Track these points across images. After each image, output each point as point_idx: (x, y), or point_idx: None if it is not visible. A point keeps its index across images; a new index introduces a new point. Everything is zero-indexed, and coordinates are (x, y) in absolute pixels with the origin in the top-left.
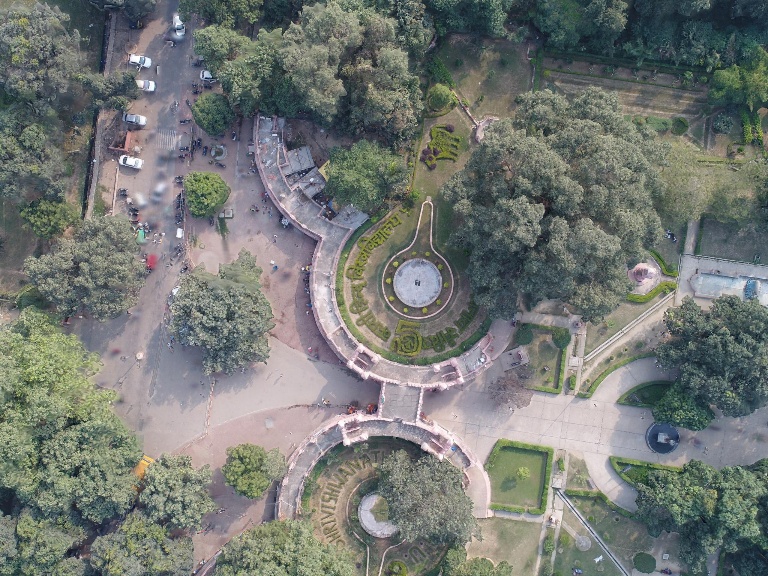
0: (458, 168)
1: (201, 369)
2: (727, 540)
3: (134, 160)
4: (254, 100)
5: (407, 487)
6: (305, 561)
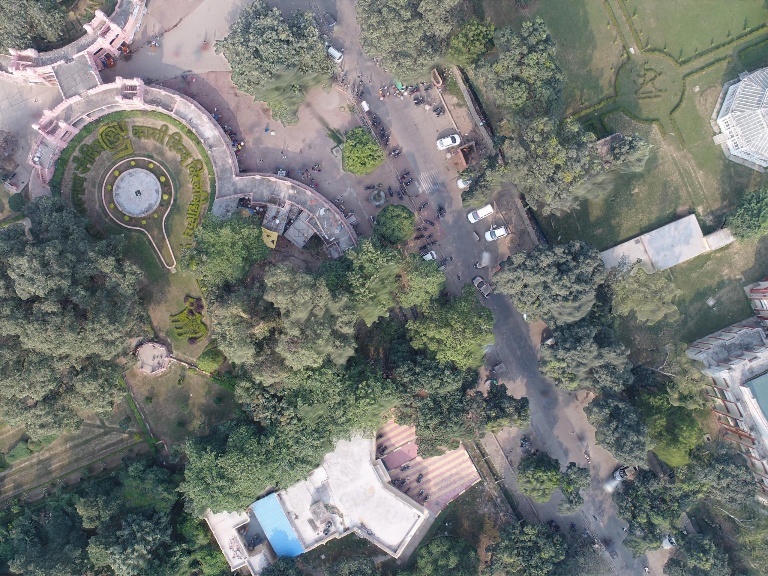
0: (165, 311)
1: (277, 4)
2: None
3: (446, 144)
4: None
5: (19, 5)
6: None
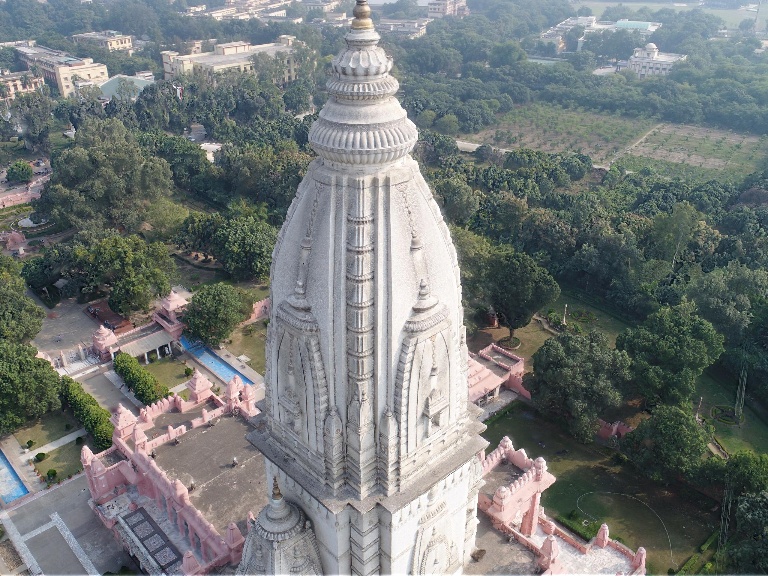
0: None
1: None
2: None
3: None
4: None
5: None
6: None
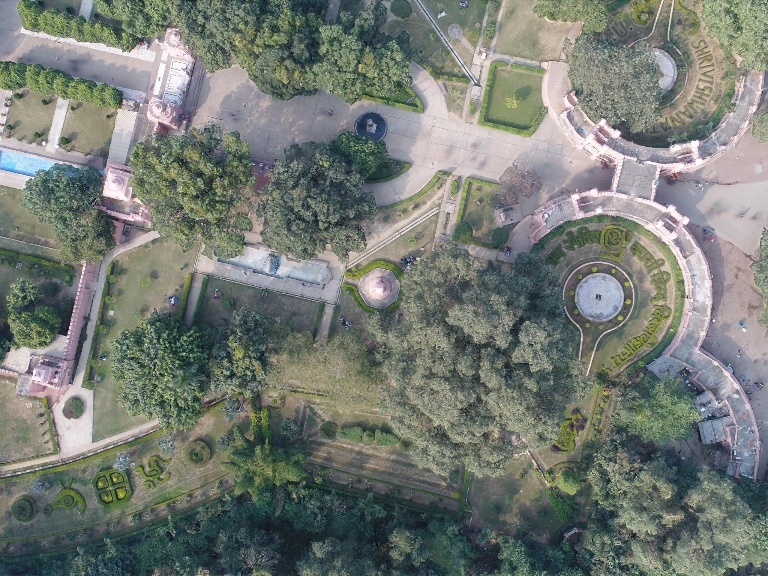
0: None
1: None
2: (350, 24)
3: None
4: None
5: None
6: (762, 28)
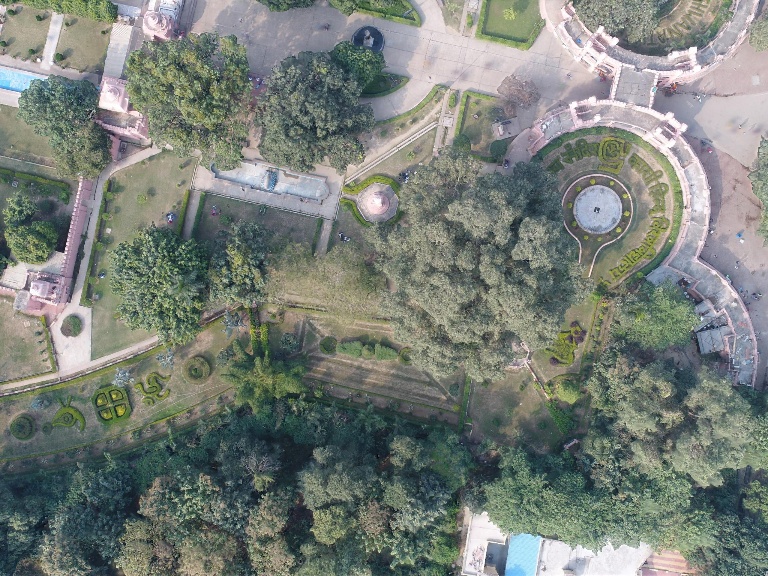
0: None
1: None
2: None
3: None
4: (767, 399)
5: None
6: None
